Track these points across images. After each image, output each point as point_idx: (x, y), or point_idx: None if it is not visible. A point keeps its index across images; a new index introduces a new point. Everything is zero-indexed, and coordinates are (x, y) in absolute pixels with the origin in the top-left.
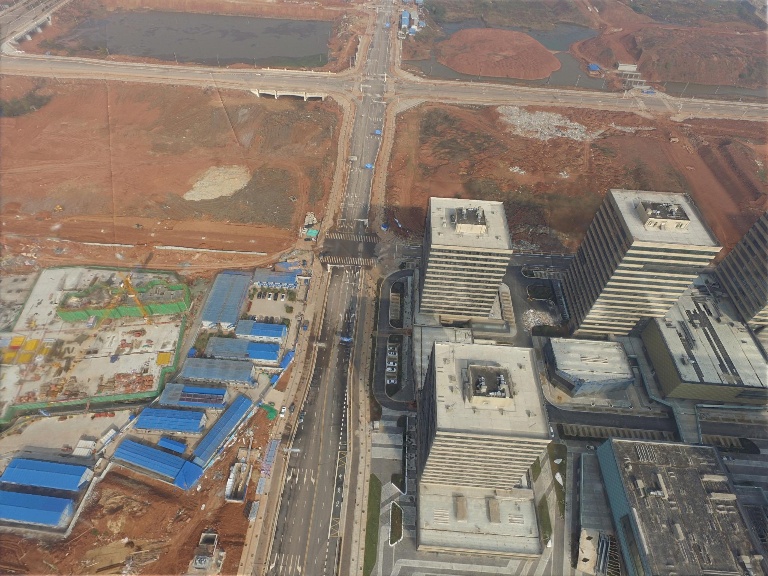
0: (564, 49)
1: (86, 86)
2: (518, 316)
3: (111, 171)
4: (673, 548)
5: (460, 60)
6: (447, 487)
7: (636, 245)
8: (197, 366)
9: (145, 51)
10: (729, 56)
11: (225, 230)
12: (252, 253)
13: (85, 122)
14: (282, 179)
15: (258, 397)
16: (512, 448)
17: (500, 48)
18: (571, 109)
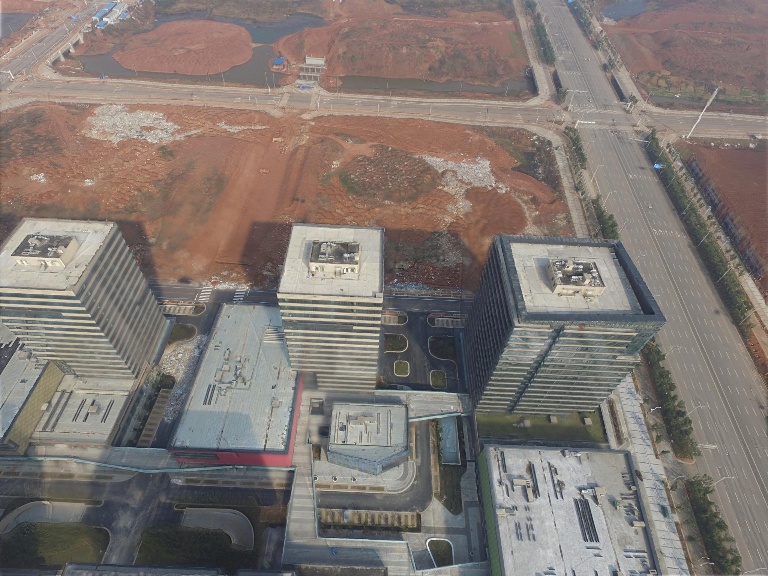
0: (270, 42)
1: None
2: None
3: None
4: None
5: (131, 55)
6: None
7: None
8: None
9: None
10: (421, 48)
11: None
12: None
13: None
14: None
15: None
16: None
17: (192, 41)
18: (184, 107)
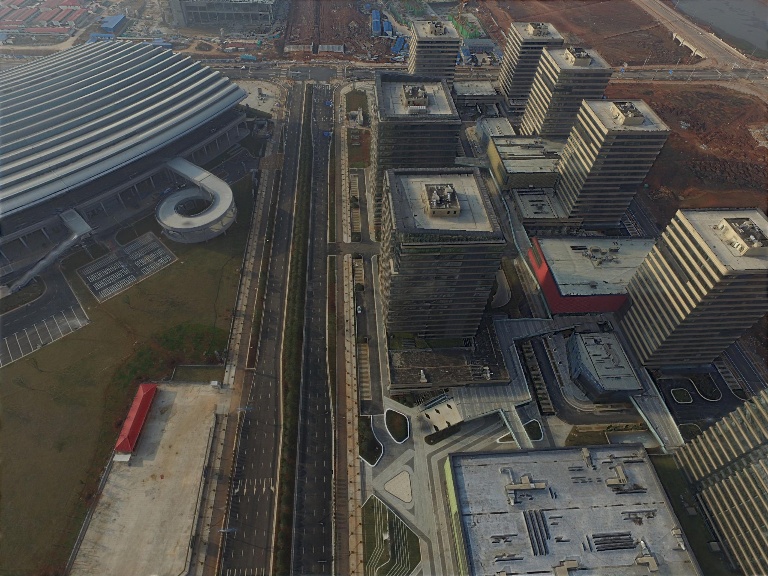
0: None
1: None
2: None
3: (546, 13)
4: None
5: None
6: None
7: None
8: None
9: (682, 2)
10: None
11: None
12: None
13: (580, 1)
14: None
15: None
16: None
17: None
18: None
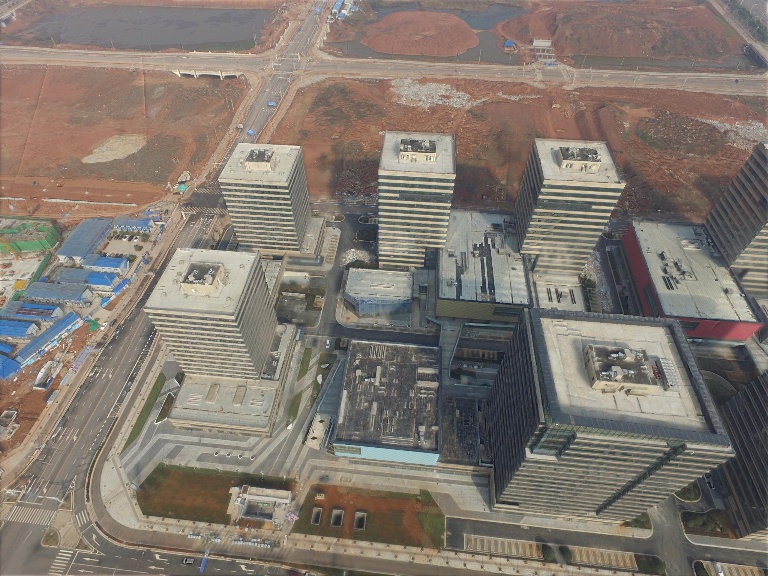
0: (488, 28)
1: (28, 71)
2: (339, 254)
3: (26, 140)
4: (365, 420)
5: (379, 40)
6: (208, 378)
7: (382, 174)
8: (39, 288)
9: (92, 40)
10: (643, 29)
11: (108, 186)
12: (124, 204)
13: (18, 100)
14: (172, 144)
15: (87, 314)
16: (214, 327)
17: (423, 28)
18: (463, 80)
